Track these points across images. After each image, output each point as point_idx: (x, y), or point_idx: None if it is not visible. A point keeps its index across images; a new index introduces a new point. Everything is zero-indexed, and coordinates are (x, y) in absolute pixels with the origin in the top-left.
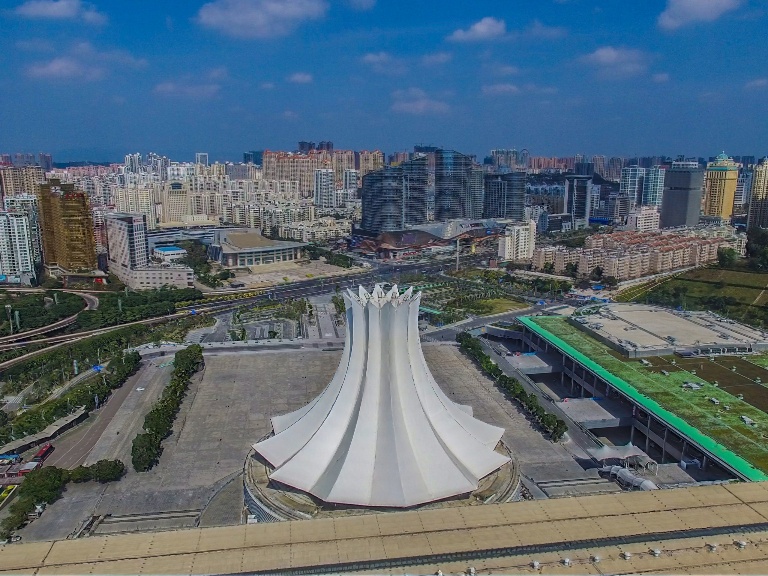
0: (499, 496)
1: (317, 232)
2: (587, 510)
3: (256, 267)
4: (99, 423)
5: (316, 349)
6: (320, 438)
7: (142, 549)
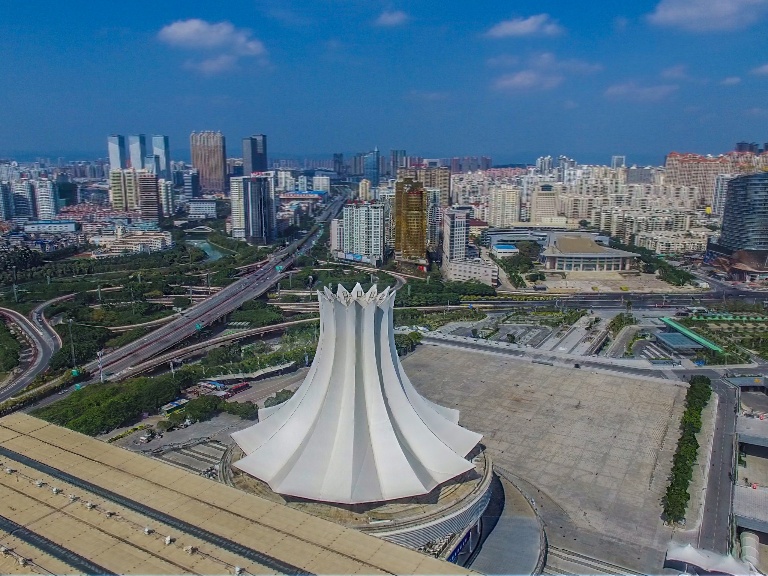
0: (391, 523)
1: (673, 244)
2: (373, 556)
3: (573, 273)
4: (296, 377)
5: (532, 359)
6: (280, 414)
7: (73, 445)
